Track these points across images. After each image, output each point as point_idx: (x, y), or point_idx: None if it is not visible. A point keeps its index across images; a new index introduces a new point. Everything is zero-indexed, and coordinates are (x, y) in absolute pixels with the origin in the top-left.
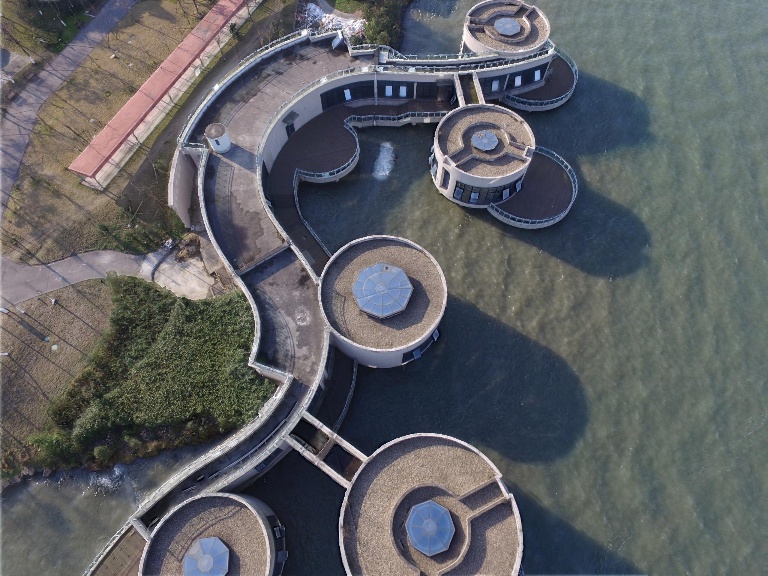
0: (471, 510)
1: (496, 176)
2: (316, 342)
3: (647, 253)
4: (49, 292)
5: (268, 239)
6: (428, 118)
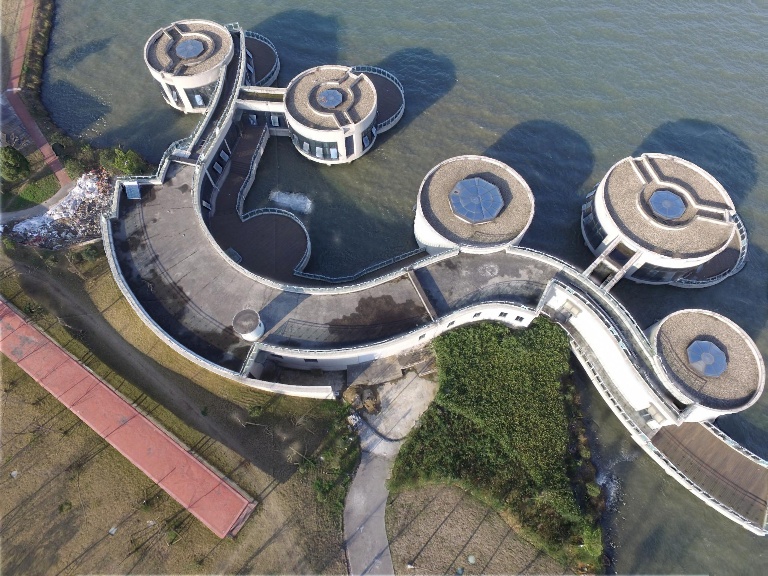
0: (652, 181)
1: (372, 101)
2: (516, 262)
3: (439, 54)
4: (395, 575)
5: (397, 292)
6: (261, 149)
